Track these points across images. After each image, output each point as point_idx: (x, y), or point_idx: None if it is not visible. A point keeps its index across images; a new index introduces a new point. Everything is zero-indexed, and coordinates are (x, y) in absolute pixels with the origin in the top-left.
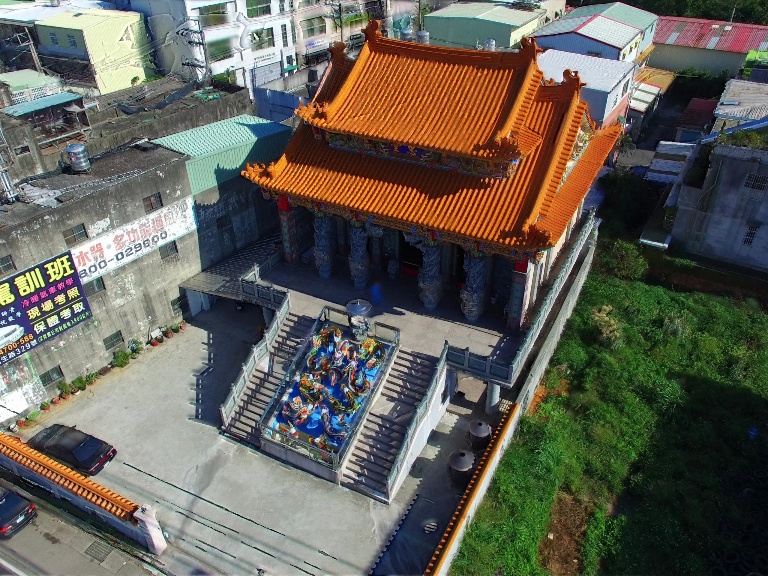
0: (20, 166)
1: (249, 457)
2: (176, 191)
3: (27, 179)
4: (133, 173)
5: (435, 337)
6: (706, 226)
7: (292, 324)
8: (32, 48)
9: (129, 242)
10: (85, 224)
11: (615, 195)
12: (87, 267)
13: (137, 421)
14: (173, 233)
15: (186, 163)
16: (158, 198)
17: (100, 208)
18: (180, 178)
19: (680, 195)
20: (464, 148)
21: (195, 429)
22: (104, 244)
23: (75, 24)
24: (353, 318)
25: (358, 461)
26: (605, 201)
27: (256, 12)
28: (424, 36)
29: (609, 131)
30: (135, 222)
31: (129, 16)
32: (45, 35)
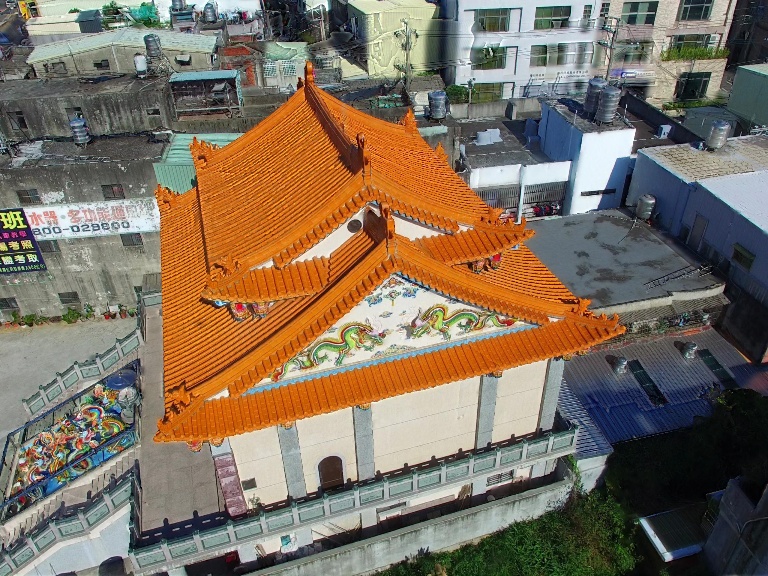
0: (150, 125)
1: (8, 459)
2: (141, 188)
3: (44, 138)
4: (101, 159)
5: (176, 460)
6: (748, 575)
7: (130, 361)
8: (322, 24)
9: (86, 219)
10: (39, 190)
11: (696, 428)
12: (41, 227)
13: (14, 373)
14: (138, 226)
15: (154, 165)
16: (122, 189)
17: (54, 181)
18: (146, 177)
19: (724, 493)
20: (215, 256)
21: (23, 407)
22: (59, 213)
23: (369, 8)
24: (126, 388)
25: (21, 530)
26: (691, 428)
27: (548, 24)
28: (608, 94)
29: (596, 324)
30: (93, 203)
31: (423, 8)
32: (351, 14)
